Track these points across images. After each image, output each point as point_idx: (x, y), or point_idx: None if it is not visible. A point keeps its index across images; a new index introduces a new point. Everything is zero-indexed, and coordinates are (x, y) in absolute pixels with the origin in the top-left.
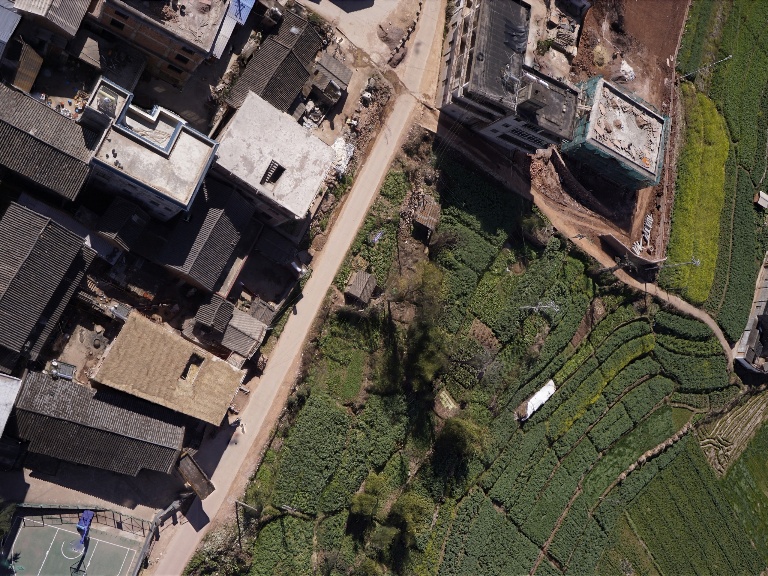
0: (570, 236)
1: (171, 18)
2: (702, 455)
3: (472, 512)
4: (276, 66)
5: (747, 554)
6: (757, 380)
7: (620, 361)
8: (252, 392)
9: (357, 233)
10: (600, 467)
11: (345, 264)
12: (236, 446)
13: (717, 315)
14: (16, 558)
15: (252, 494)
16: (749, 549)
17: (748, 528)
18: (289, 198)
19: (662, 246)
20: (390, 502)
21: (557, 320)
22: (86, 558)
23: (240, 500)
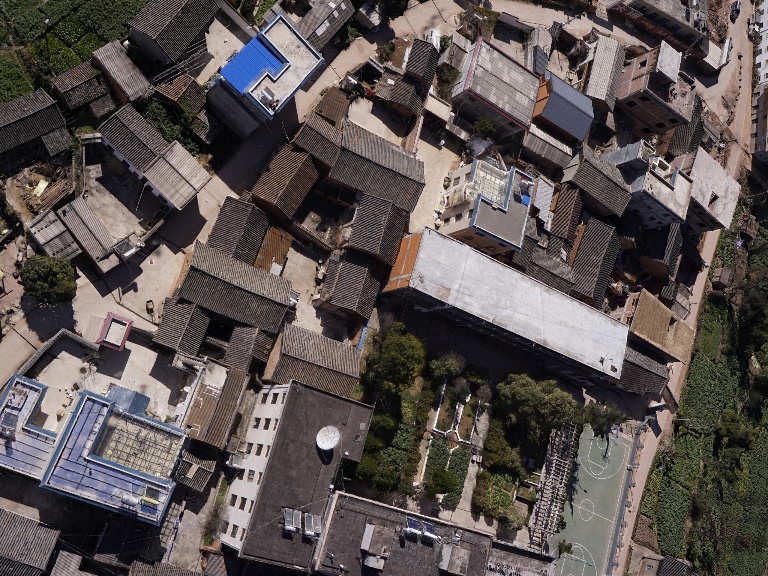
0: None
1: (670, 101)
2: None
3: (763, 445)
4: (693, 128)
5: None
6: None
7: None
8: None
9: (718, 241)
10: None
11: (713, 262)
12: (670, 383)
13: None
14: None
15: None
16: None
17: None
18: (722, 216)
19: None
20: None
21: None
22: (608, 449)
23: None
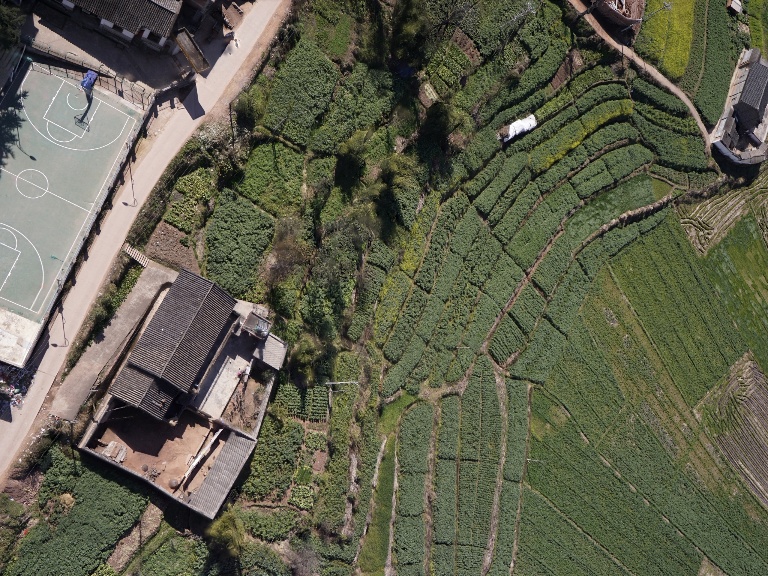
0: None
1: None
2: (683, 232)
3: (457, 212)
4: None
5: (730, 333)
6: (735, 173)
7: (599, 116)
8: (245, 14)
9: None
10: (582, 215)
11: None
12: (230, 56)
13: (693, 97)
14: (25, 95)
15: (245, 95)
16: (732, 329)
17: (730, 309)
18: None
19: (637, 11)
20: (377, 169)
21: (536, 53)
22: (89, 113)
23: (234, 104)
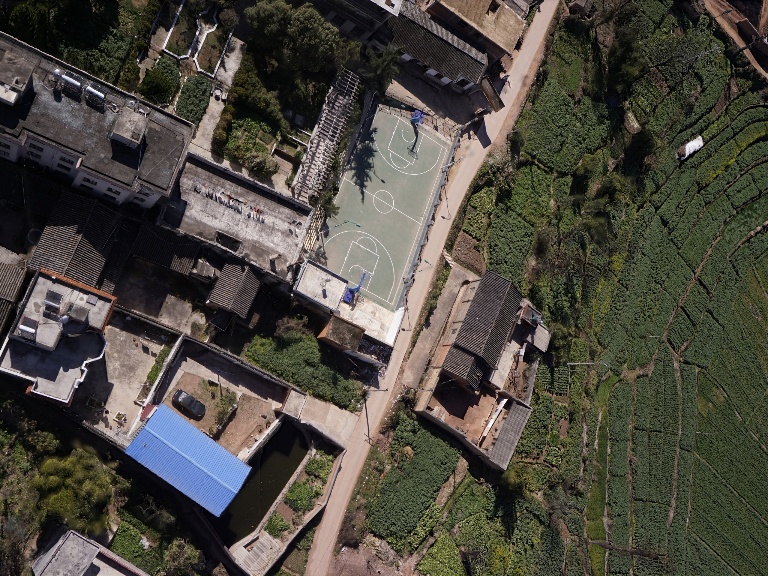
0: (716, 17)
1: None
2: None
3: (647, 221)
4: None
5: None
6: None
7: (749, 136)
8: (514, 60)
9: None
10: (734, 222)
11: None
12: (506, 95)
13: None
14: (375, 131)
15: None
16: None
17: None
18: None
19: None
20: (596, 186)
21: (707, 83)
22: (417, 144)
23: (509, 135)
